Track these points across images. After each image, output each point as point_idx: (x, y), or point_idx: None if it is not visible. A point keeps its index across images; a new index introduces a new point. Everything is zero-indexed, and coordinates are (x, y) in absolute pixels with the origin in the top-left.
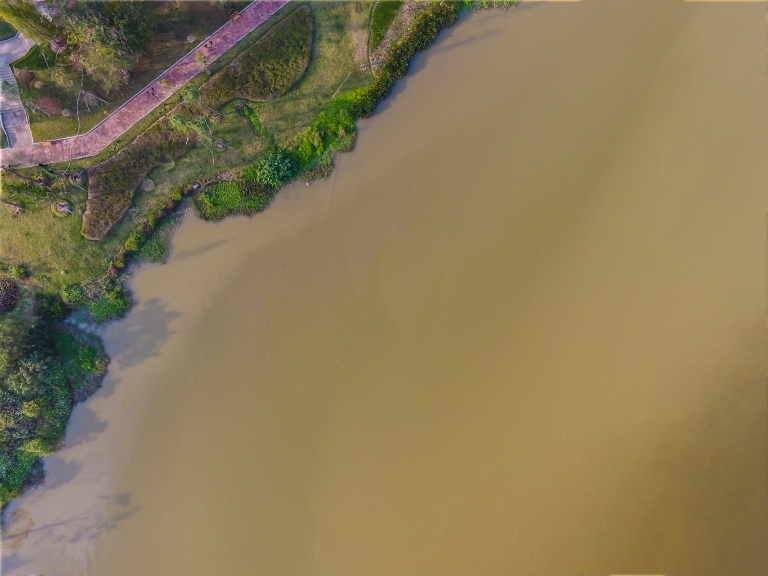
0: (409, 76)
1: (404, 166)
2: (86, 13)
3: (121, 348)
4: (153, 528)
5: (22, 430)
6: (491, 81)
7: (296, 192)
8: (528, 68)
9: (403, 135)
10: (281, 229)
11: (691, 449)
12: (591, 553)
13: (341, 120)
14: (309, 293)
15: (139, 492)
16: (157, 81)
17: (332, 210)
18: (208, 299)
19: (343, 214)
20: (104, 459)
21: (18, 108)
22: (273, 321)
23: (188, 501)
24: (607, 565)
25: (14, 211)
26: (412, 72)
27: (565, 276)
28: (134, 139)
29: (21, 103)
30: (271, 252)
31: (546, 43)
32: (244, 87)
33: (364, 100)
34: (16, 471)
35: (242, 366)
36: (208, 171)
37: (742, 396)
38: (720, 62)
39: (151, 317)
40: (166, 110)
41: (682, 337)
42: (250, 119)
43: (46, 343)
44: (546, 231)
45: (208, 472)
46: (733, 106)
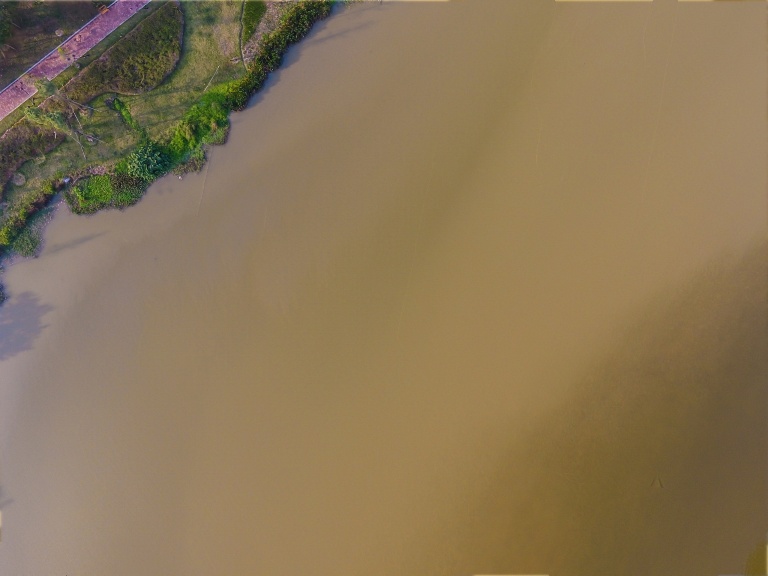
0: (282, 69)
1: (277, 159)
2: None
3: None
4: (25, 521)
5: None
6: (365, 73)
7: (169, 185)
8: (402, 60)
9: (276, 128)
10: (154, 222)
11: (563, 439)
12: (464, 543)
13: (213, 113)
14: (181, 286)
15: (11, 485)
16: (26, 75)
17: (205, 203)
18: (80, 293)
19: (216, 207)
20: None
21: None
22: (146, 314)
23: (60, 494)
24: (479, 555)
25: None
26: (285, 65)
27: (438, 268)
28: (3, 133)
29: None
30: (143, 245)
31: (421, 35)
32: (113, 81)
33: (235, 93)
34: None
35: (114, 359)
36: (80, 165)
37: (615, 386)
38: (594, 53)
39: (23, 311)
40: (35, 104)
41: (555, 328)
42: (121, 113)
43: None
44: (419, 223)
45: (80, 465)
46: (607, 97)
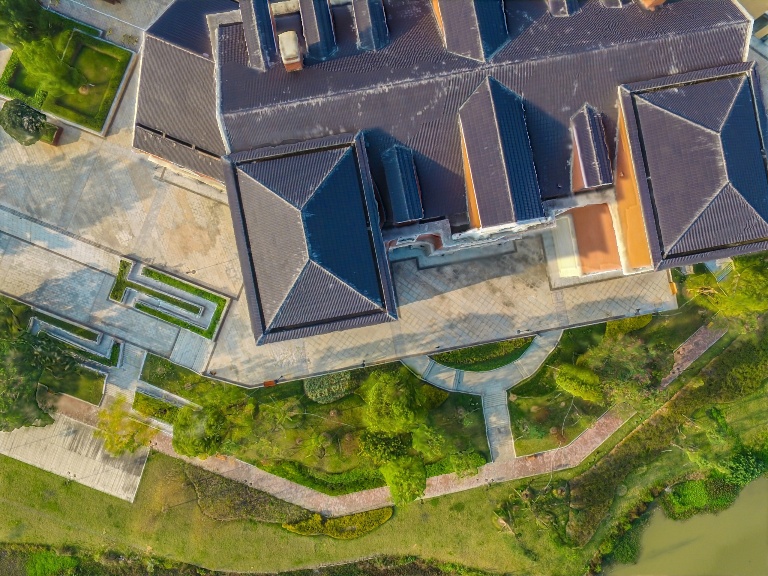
0: None
1: None
2: None
3: None
4: None
5: None
6: None
7: (760, 488)
8: None
9: None
10: (746, 525)
11: None
12: None
13: None
14: None
15: None
16: None
17: None
18: None
19: None
20: None
21: (503, 425)
22: None
23: None
24: None
25: (502, 526)
26: None
27: None
28: (612, 449)
29: (509, 422)
30: (738, 549)
31: None
32: (718, 393)
33: None
34: None
35: None
36: (676, 472)
37: None
38: None
39: None
40: (642, 419)
41: None
42: (717, 420)
43: None
44: None
45: None
46: None
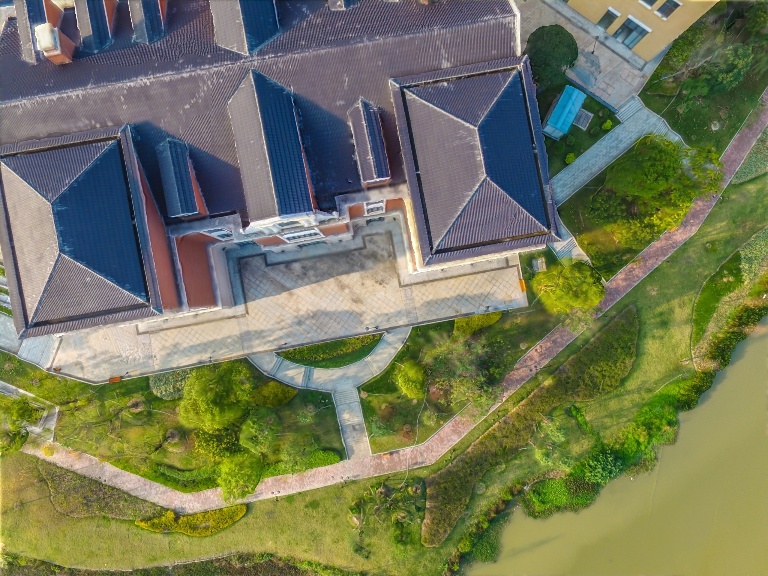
0: (728, 366)
1: (726, 458)
2: (473, 373)
3: None
4: None
5: None
6: None
7: (621, 487)
8: None
9: (723, 425)
10: (607, 524)
11: None
12: None
13: (665, 415)
14: None
15: None
16: None
17: (656, 503)
18: None
19: (666, 506)
20: None
21: (357, 422)
22: None
23: None
24: None
25: (357, 524)
26: (731, 362)
27: None
28: (469, 446)
29: (362, 419)
30: (598, 547)
31: None
32: (575, 391)
33: (689, 396)
34: None
35: None
36: (536, 470)
37: None
38: None
39: None
40: (499, 417)
41: None
42: (577, 418)
43: None
44: None
45: None
46: None
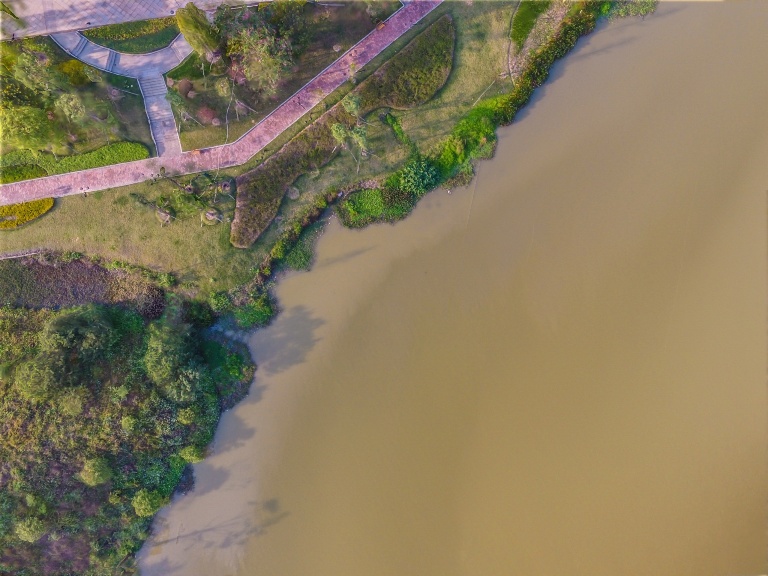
0: (547, 84)
1: (544, 173)
2: (256, 24)
3: (267, 355)
4: (302, 533)
5: (176, 437)
6: (628, 89)
7: (438, 199)
8: (664, 76)
9: (542, 143)
10: (423, 236)
11: None
12: None
13: (482, 128)
14: (452, 300)
15: (288, 498)
16: (303, 90)
17: (473, 217)
18: (352, 306)
19: (484, 221)
20: (253, 465)
21: (167, 117)
22: (416, 328)
23: (336, 506)
24: (749, 568)
25: (164, 220)
26: (550, 80)
27: (704, 282)
28: (281, 148)
29: (171, 112)
30: (414, 259)
31: (681, 51)
32: (389, 96)
33: (505, 108)
34: (169, 477)
35: (388, 372)
36: (351, 179)
37: None
38: None
39: (297, 324)
40: (312, 119)
41: None
42: (393, 127)
43: (197, 350)
44: (684, 237)
45: (355, 478)
46: None
